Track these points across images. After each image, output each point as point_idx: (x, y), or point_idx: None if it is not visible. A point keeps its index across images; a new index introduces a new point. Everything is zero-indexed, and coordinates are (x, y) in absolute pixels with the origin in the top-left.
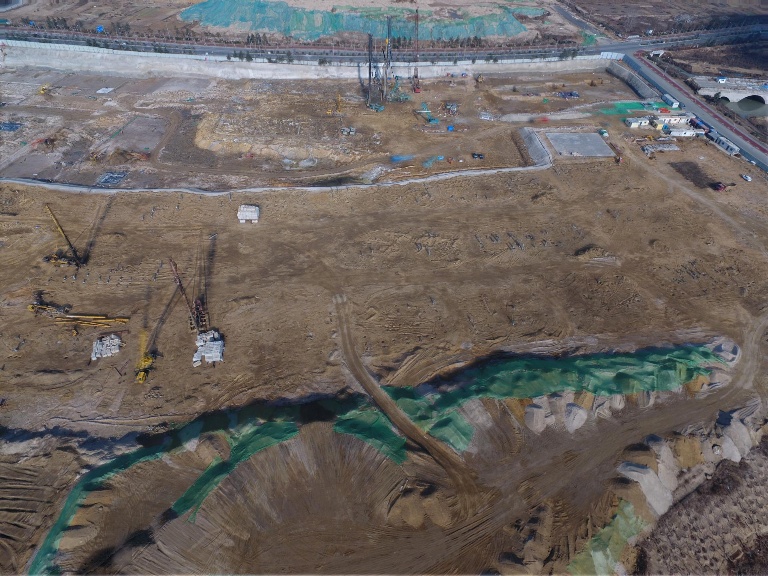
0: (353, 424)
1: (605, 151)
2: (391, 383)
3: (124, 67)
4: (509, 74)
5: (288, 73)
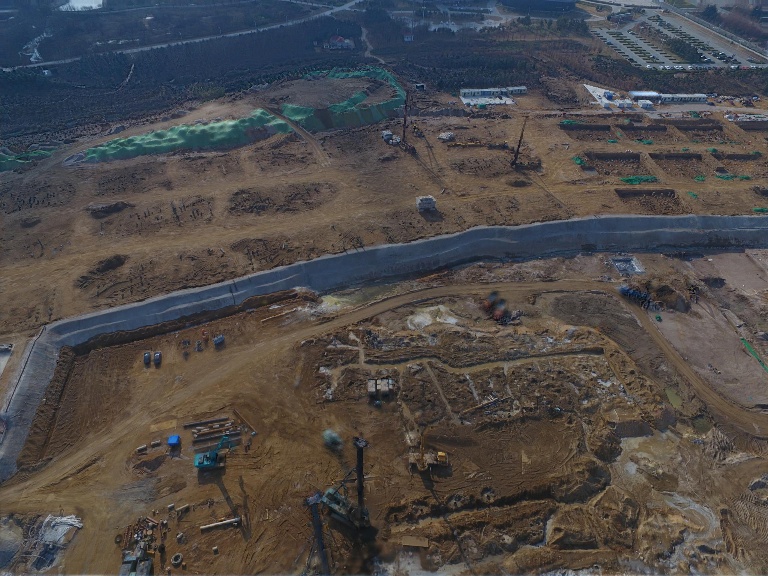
0: (306, 113)
1: None
2: None
3: None
4: None
5: None
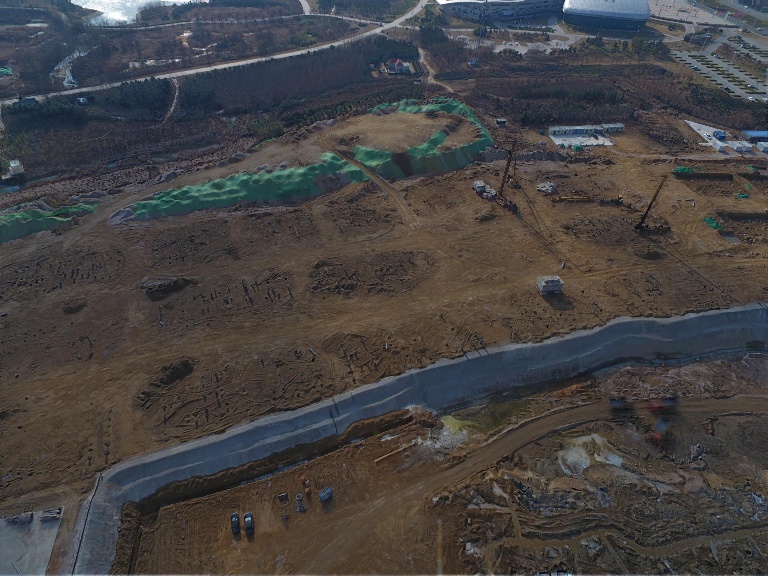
0: (382, 157)
1: None
2: (365, 183)
3: None
4: None
5: None
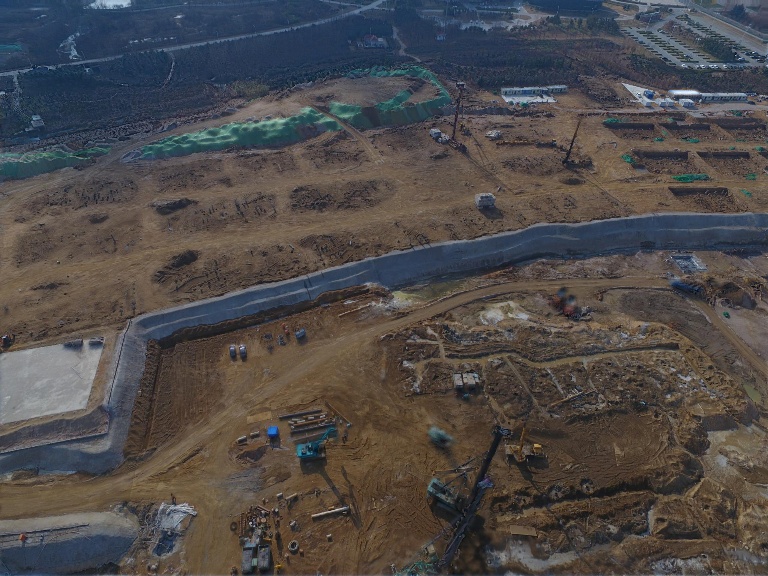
0: (353, 111)
1: (8, 364)
2: None
3: None
4: None
5: None
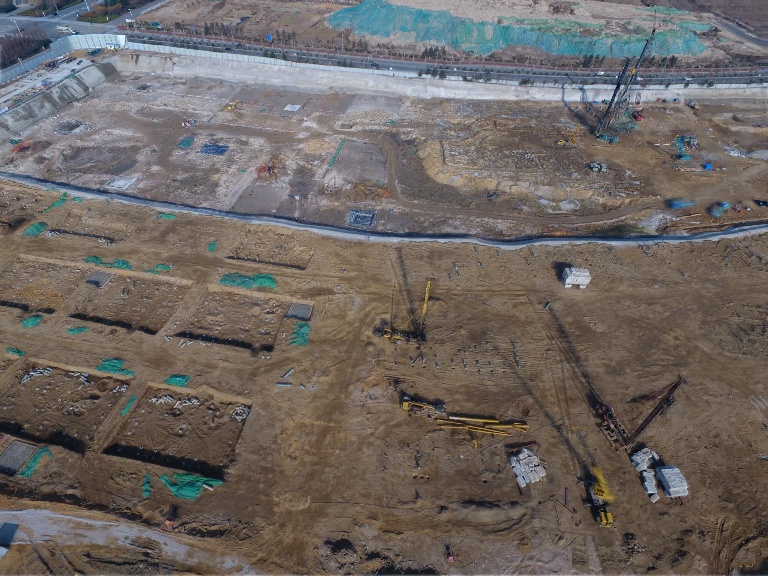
0: None
1: None
2: None
3: (304, 81)
4: (722, 100)
5: (484, 93)
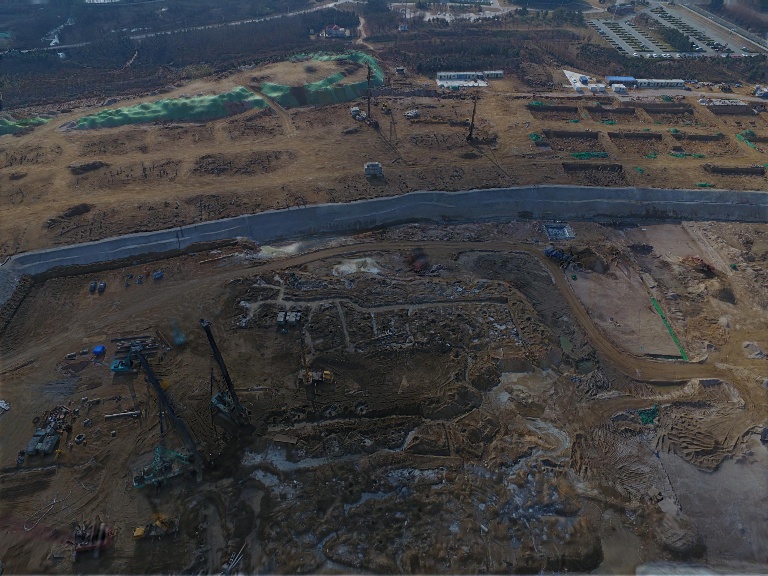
0: (282, 91)
1: None
2: None
3: None
4: None
5: None
